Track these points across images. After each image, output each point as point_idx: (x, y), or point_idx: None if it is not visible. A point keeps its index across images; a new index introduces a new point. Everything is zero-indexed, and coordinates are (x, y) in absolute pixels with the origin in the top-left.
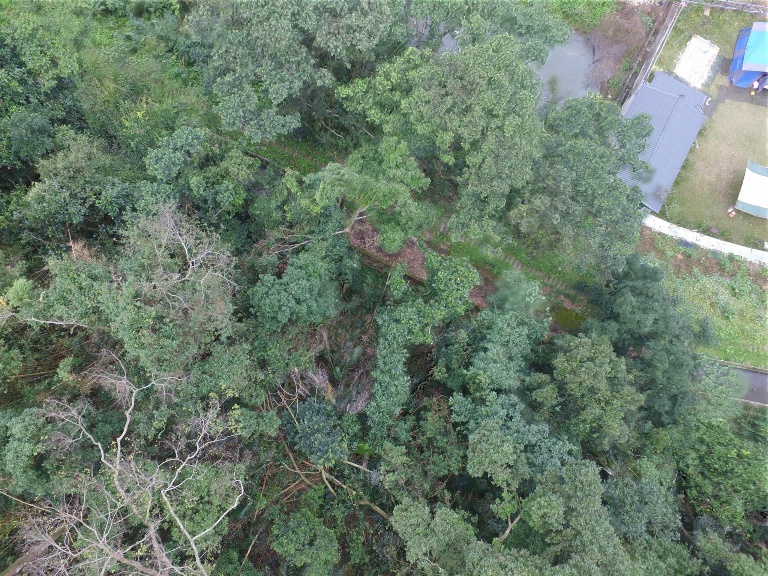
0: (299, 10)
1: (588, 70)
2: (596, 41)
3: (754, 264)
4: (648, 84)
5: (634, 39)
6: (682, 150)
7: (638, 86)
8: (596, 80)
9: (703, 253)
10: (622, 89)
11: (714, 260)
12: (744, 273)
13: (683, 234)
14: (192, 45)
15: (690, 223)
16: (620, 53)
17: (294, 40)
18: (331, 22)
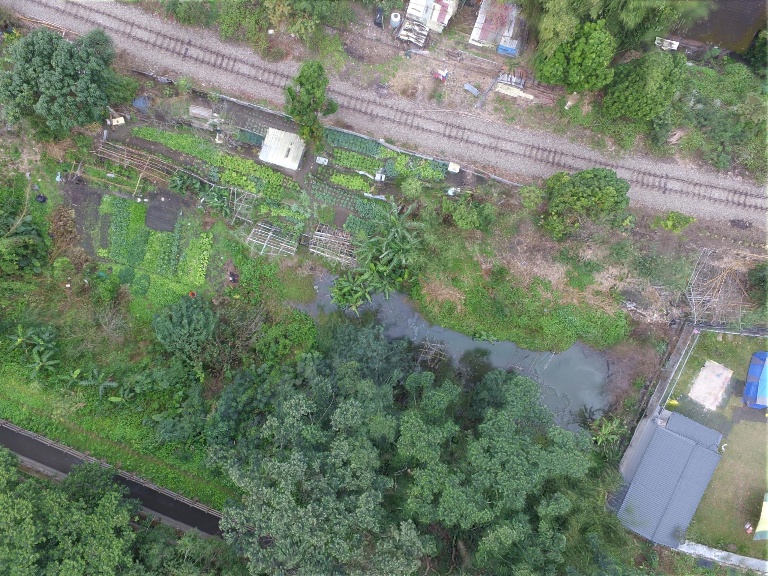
0: (332, 536)
1: (603, 383)
2: (610, 358)
3: None
4: (664, 425)
5: (648, 369)
6: (699, 489)
7: (653, 411)
8: (611, 392)
9: (722, 571)
10: (637, 410)
11: None
12: None
13: (701, 551)
14: (219, 433)
15: (708, 539)
16: (634, 373)
17: (328, 571)
18: (365, 569)
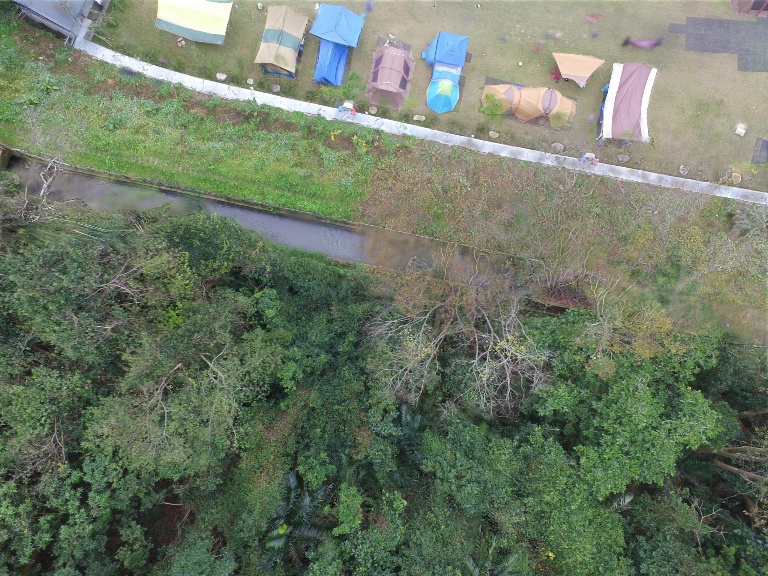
0: None
1: None
2: None
3: (204, 94)
4: None
5: None
6: None
7: None
8: None
9: (145, 81)
10: None
11: (156, 88)
12: (180, 99)
13: (128, 63)
14: None
15: (138, 53)
16: None
17: None
18: None
